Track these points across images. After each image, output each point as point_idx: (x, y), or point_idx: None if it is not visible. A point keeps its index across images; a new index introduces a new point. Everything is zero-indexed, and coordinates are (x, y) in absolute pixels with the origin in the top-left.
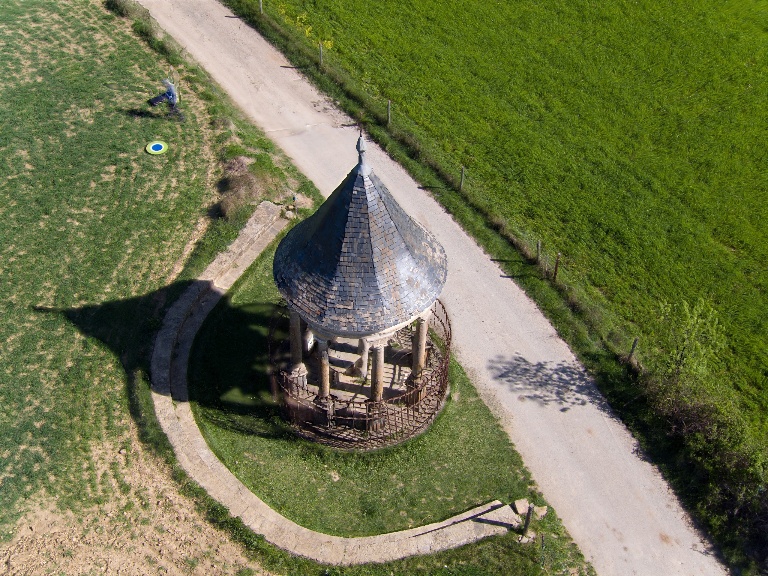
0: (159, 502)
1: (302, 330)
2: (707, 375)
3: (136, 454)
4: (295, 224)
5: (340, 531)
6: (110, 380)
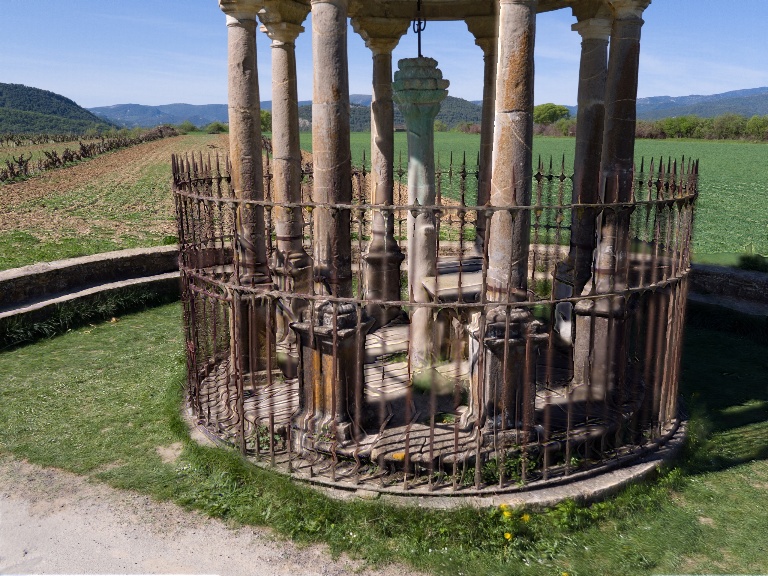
0: None
1: None
2: None
3: None
4: None
5: None
6: None
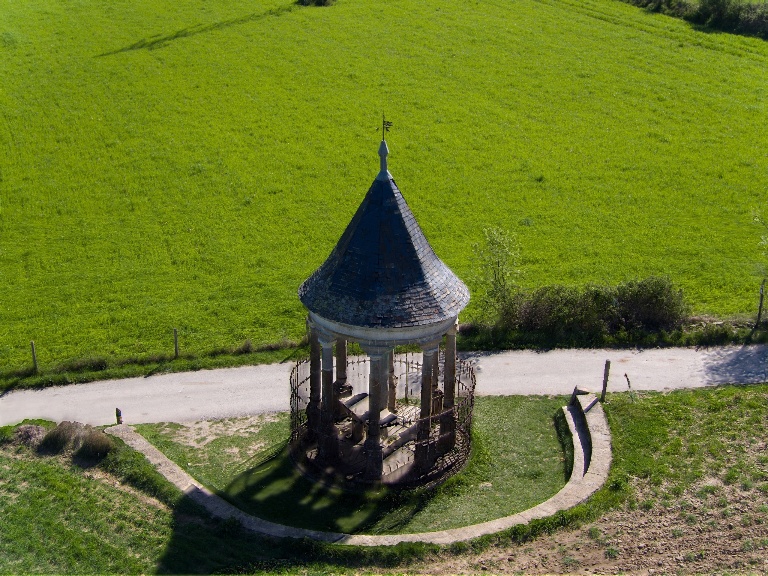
0: (485, 567)
1: (333, 427)
2: (477, 316)
3: (412, 571)
4: None
5: (552, 492)
6: (289, 574)
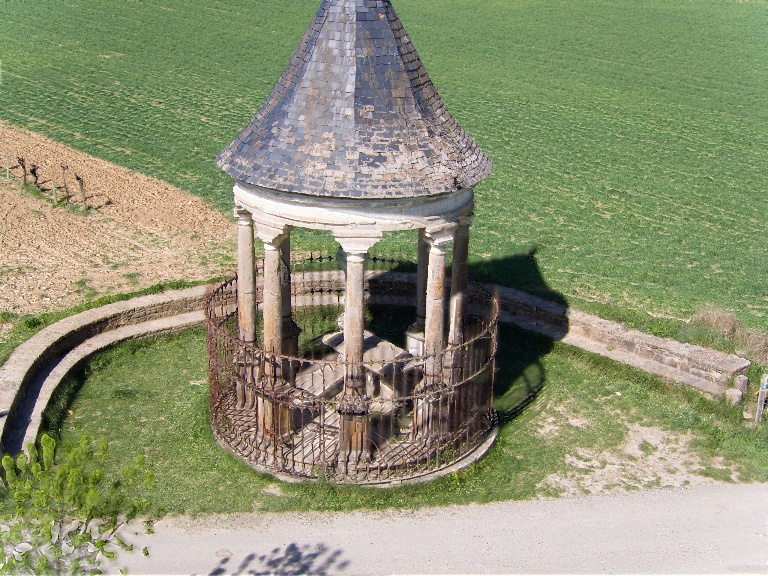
0: None
1: None
2: None
3: None
4: (724, 409)
5: (111, 370)
6: None
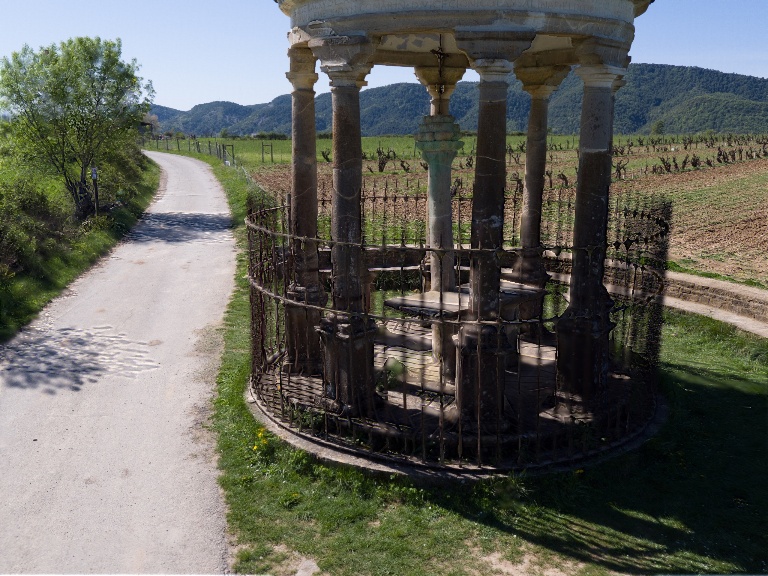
0: None
1: None
2: None
3: None
4: None
5: None
6: None
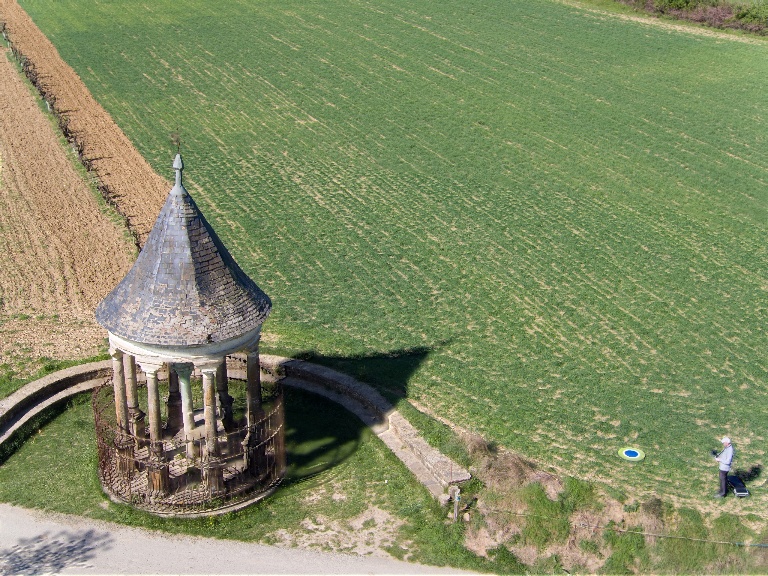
0: None
1: None
2: None
3: None
4: (436, 507)
5: (85, 406)
6: None
